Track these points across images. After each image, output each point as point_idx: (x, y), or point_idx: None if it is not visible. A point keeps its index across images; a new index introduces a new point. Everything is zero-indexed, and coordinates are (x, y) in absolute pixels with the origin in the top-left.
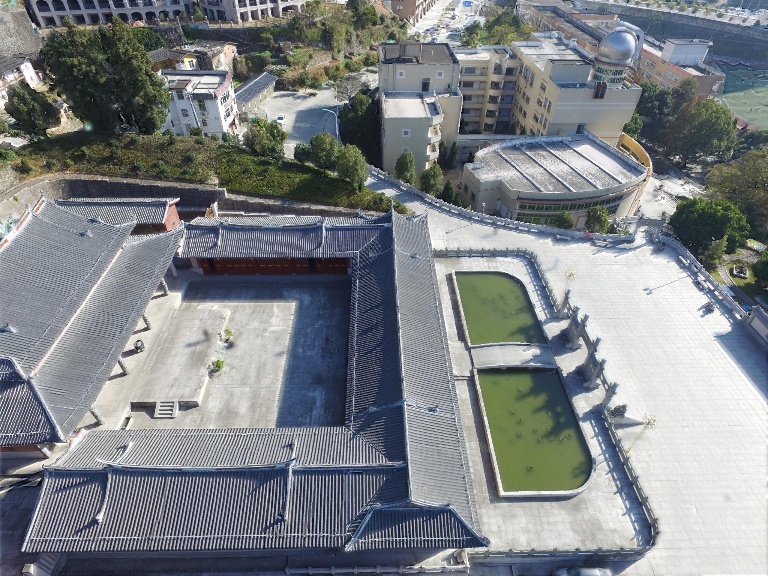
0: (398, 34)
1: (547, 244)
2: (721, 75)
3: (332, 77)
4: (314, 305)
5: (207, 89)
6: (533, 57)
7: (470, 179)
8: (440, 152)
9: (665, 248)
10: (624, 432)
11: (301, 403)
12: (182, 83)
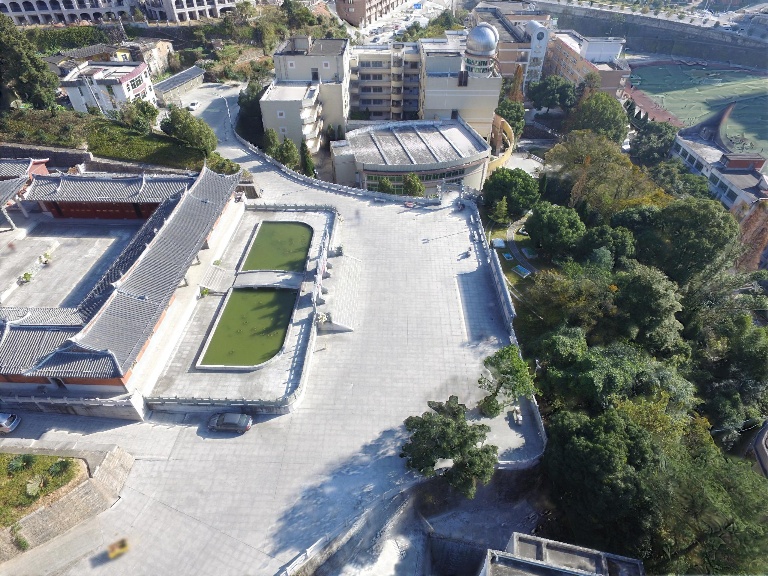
0: (335, 33)
1: (364, 205)
2: (627, 70)
3: None
4: None
5: (118, 77)
6: None
7: (332, 155)
8: (327, 134)
9: (465, 210)
10: (333, 336)
11: None
12: (93, 71)
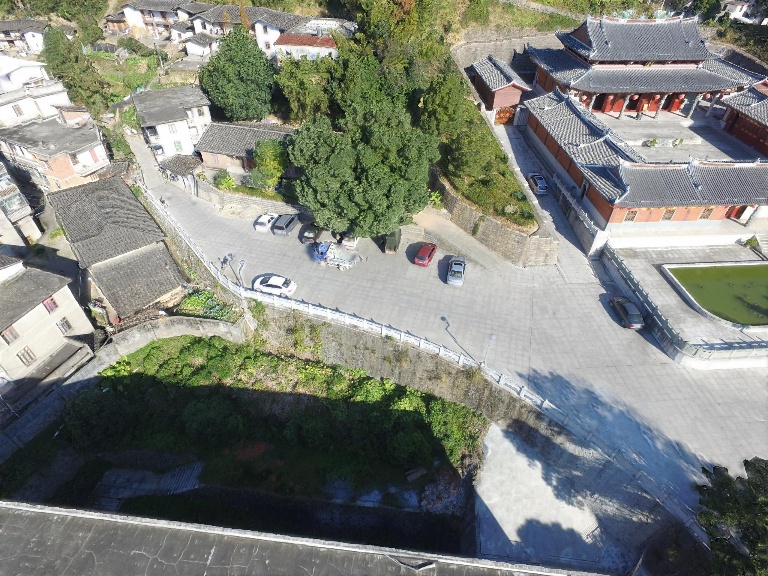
0: None
1: None
2: None
3: None
4: None
5: None
6: None
7: None
8: None
9: None
10: None
11: None
12: None
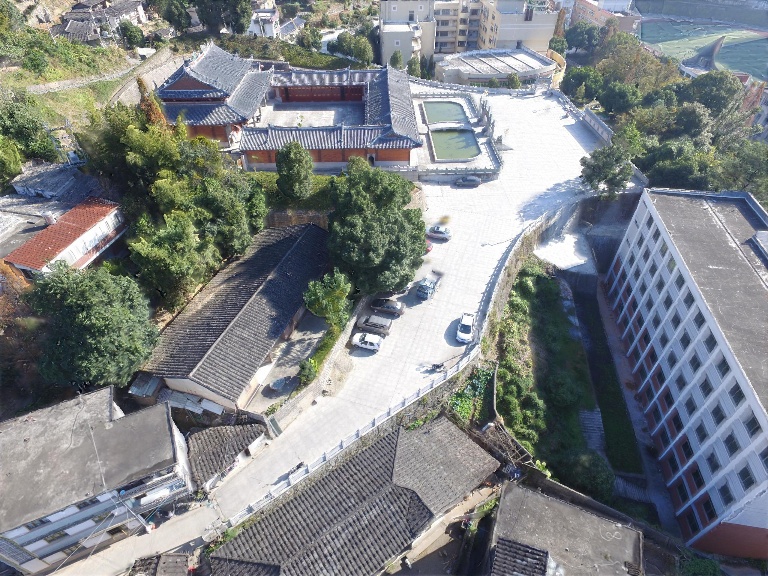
0: None
1: None
2: (638, 16)
3: (345, 20)
4: (345, 111)
5: None
6: (490, 0)
7: (439, 71)
8: (422, 63)
9: (553, 96)
10: None
11: None
12: None
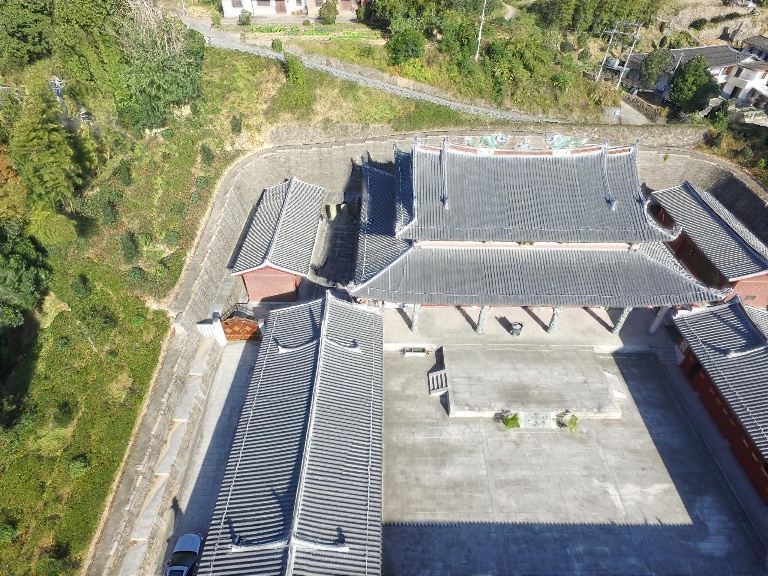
0: None
1: None
2: None
3: None
4: (706, 566)
5: None
6: None
7: None
8: None
9: None
10: None
11: (470, 564)
12: None
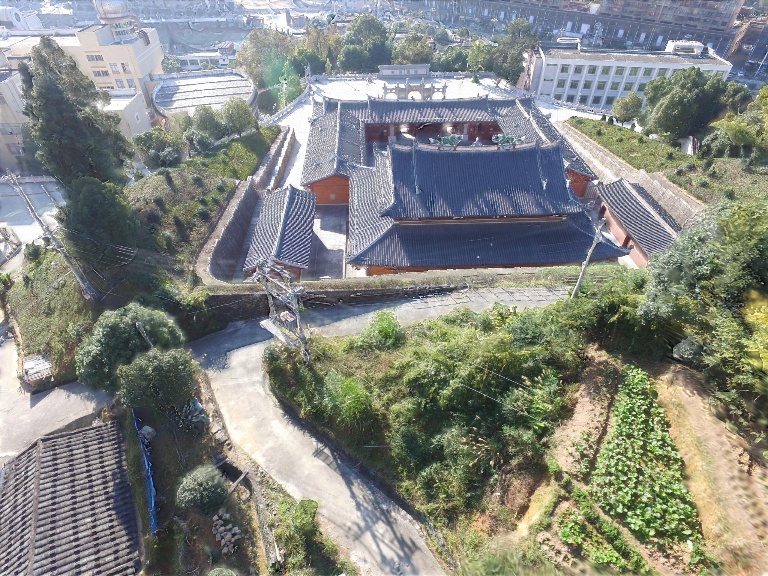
0: None
1: (309, 106)
2: None
3: None
4: None
5: None
6: None
7: None
8: None
9: None
10: None
11: None
12: None
